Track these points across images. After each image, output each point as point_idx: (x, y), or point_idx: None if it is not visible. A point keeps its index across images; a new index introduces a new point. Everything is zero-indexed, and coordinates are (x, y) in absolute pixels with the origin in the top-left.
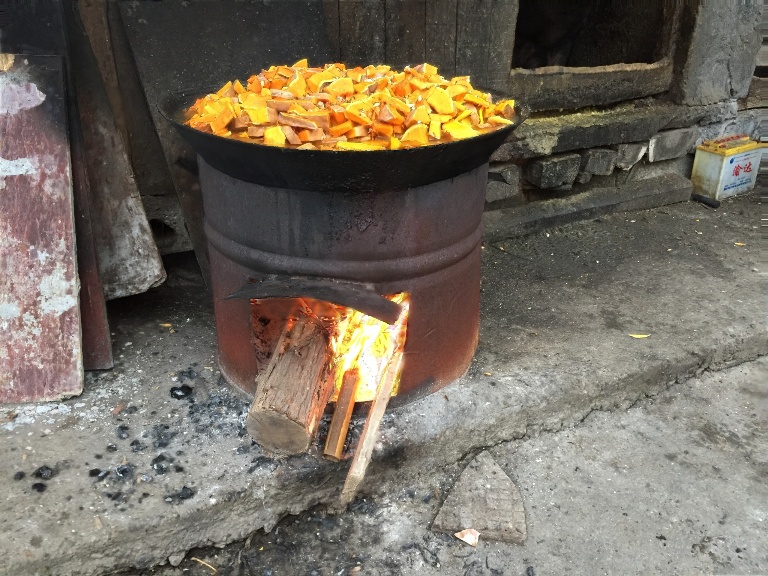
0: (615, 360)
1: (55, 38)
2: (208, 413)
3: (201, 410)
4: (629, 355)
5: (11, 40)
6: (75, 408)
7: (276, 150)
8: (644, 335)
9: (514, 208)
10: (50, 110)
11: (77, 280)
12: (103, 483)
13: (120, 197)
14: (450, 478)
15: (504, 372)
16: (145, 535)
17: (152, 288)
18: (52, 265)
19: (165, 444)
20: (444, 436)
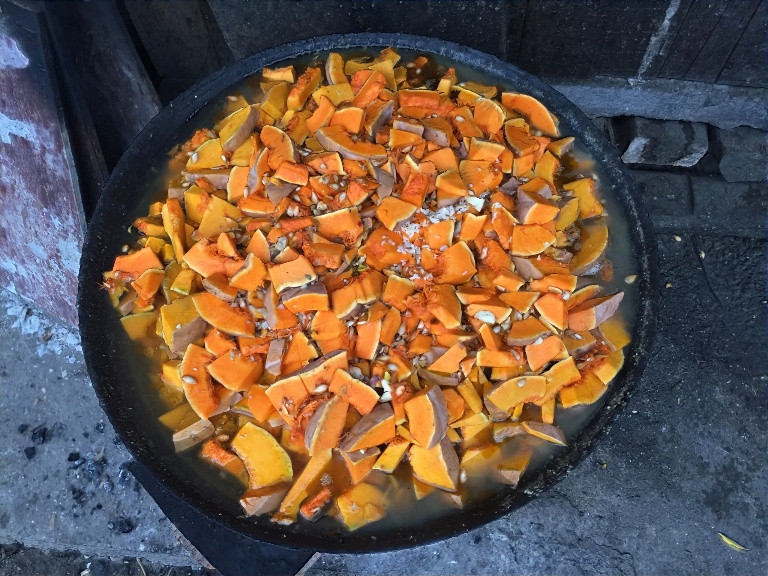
0: (660, 569)
1: None
2: None
3: None
4: (687, 569)
5: None
6: None
7: None
8: (739, 545)
9: None
10: (36, 79)
11: None
12: (75, 472)
13: None
14: None
15: (508, 522)
16: None
17: None
18: (65, 233)
19: None
20: (385, 574)
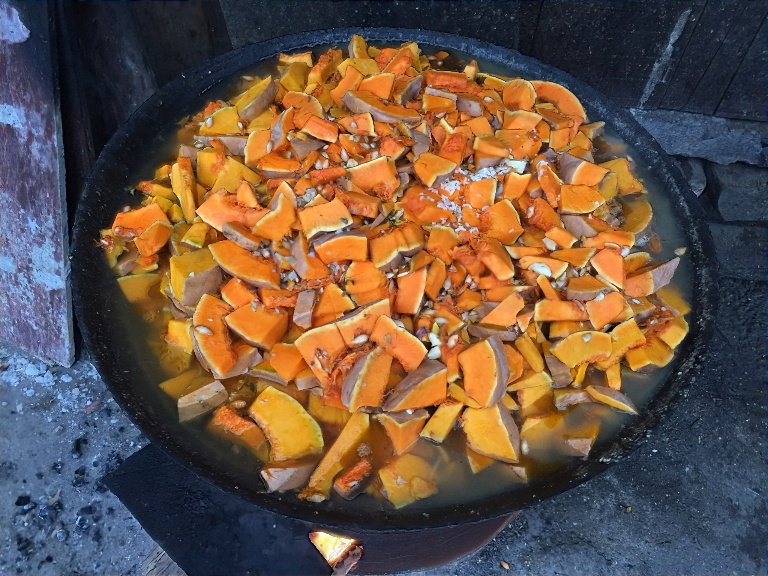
0: None
1: None
2: None
3: None
4: None
5: None
6: (60, 382)
7: None
8: None
9: (767, 235)
10: (35, 54)
11: (67, 262)
12: (23, 519)
13: None
14: None
15: (529, 572)
16: None
17: None
18: (42, 238)
19: (105, 489)
20: None
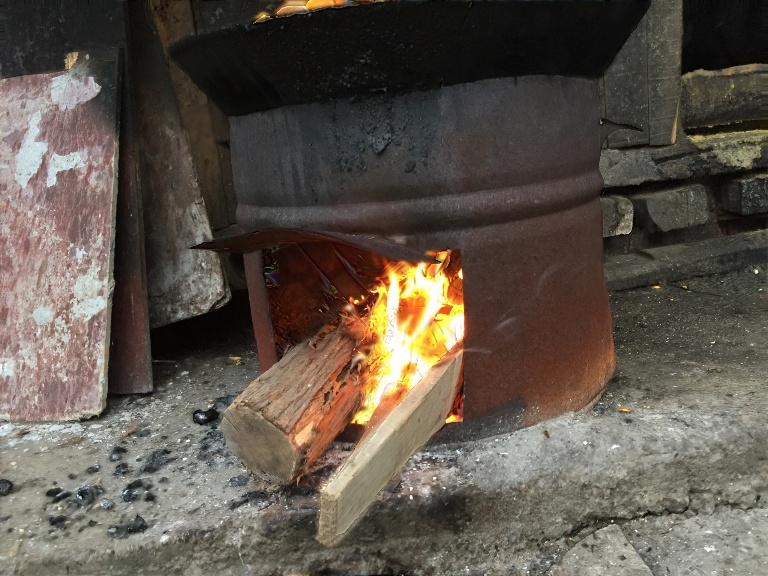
0: None
1: (116, 31)
2: (224, 439)
3: (219, 437)
4: None
5: (79, 40)
6: (89, 428)
7: (241, 31)
8: None
9: (703, 240)
10: (103, 101)
11: (111, 280)
12: (56, 505)
13: (184, 204)
14: (548, 560)
15: (652, 409)
16: (66, 574)
17: (216, 309)
18: (88, 263)
19: (154, 469)
20: (535, 488)
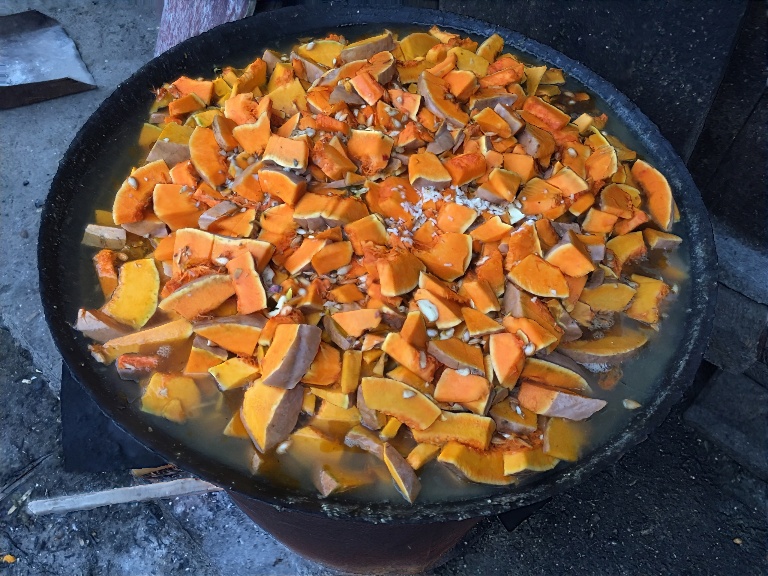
0: None
1: None
2: None
3: None
4: None
5: None
6: None
7: None
8: None
9: None
10: None
11: None
12: None
13: None
14: None
15: None
16: None
17: None
18: None
19: None
20: None
